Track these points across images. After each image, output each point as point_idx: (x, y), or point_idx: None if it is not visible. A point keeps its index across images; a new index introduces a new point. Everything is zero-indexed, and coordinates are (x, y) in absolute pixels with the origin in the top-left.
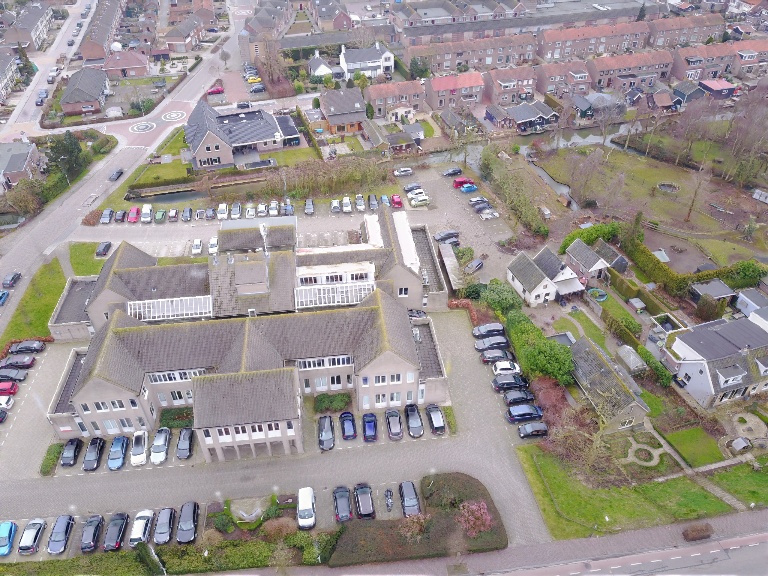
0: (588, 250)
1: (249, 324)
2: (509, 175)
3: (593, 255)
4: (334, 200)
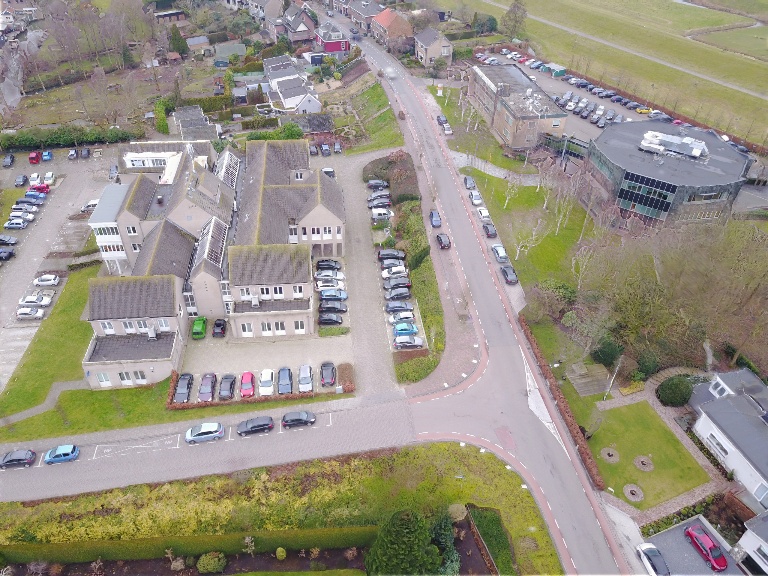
0: (188, 112)
1: None
2: (53, 130)
3: (195, 111)
4: (6, 223)
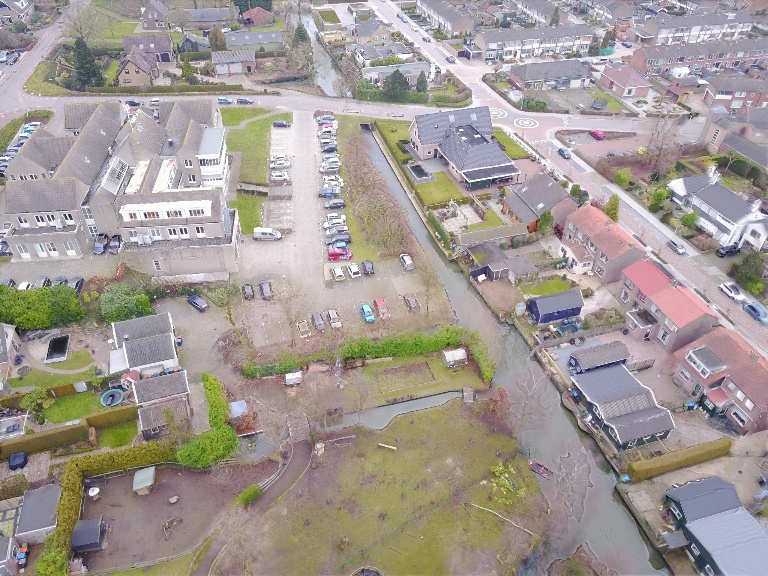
0: None
1: (73, 137)
2: (379, 342)
3: None
4: (343, 215)
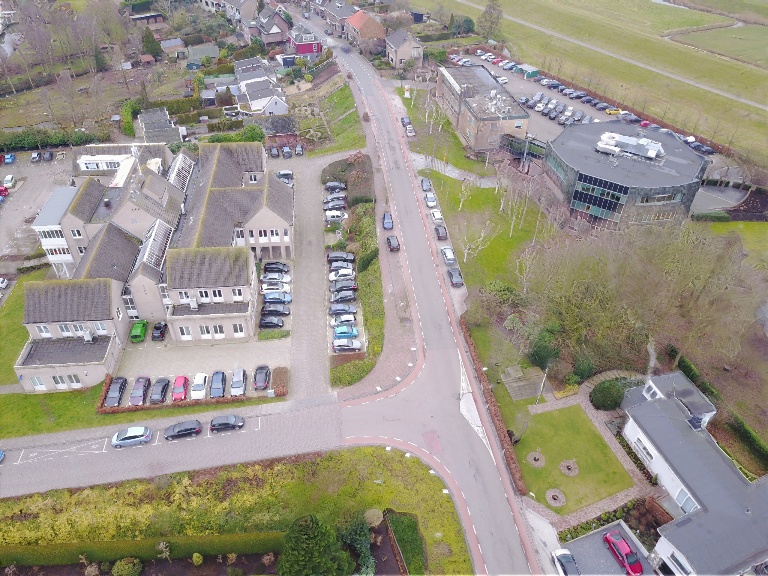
0: (154, 114)
1: None
2: (17, 133)
3: (160, 114)
4: None
